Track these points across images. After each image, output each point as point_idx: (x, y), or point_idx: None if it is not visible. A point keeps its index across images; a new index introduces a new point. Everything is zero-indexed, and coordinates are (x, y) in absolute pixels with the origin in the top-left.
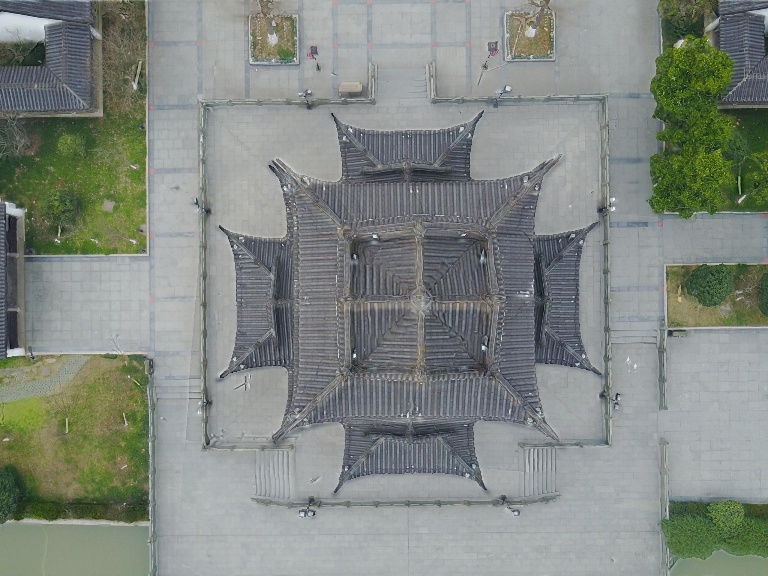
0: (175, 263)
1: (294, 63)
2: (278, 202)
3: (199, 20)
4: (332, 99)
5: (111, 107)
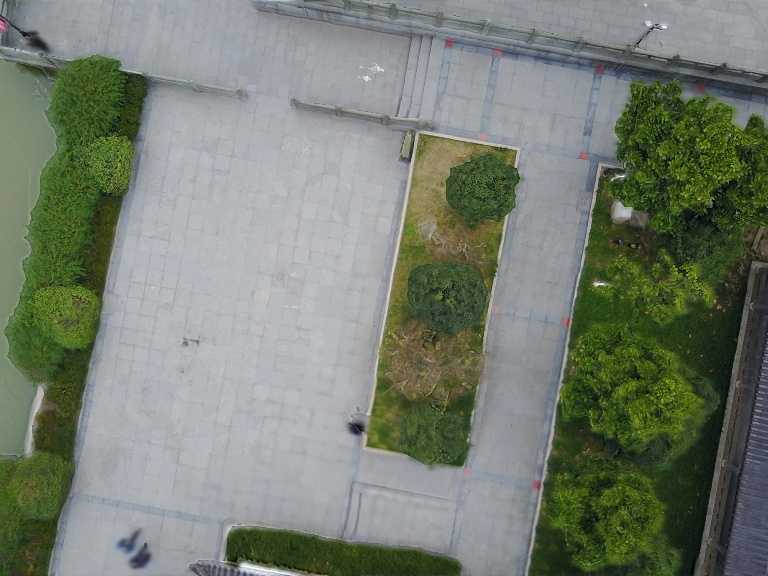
0: None
1: None
2: None
3: None
4: None
5: None
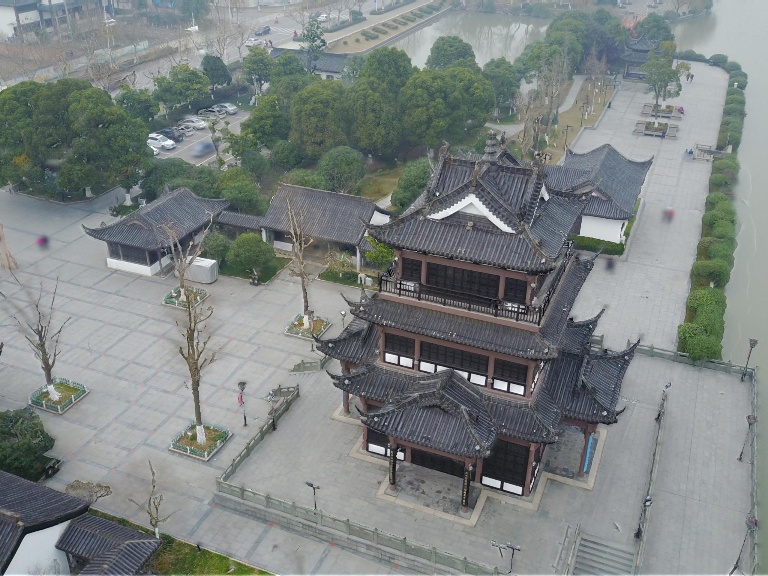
0: (347, 575)
1: (230, 436)
2: (339, 471)
3: (142, 481)
4: (280, 407)
5: (159, 569)
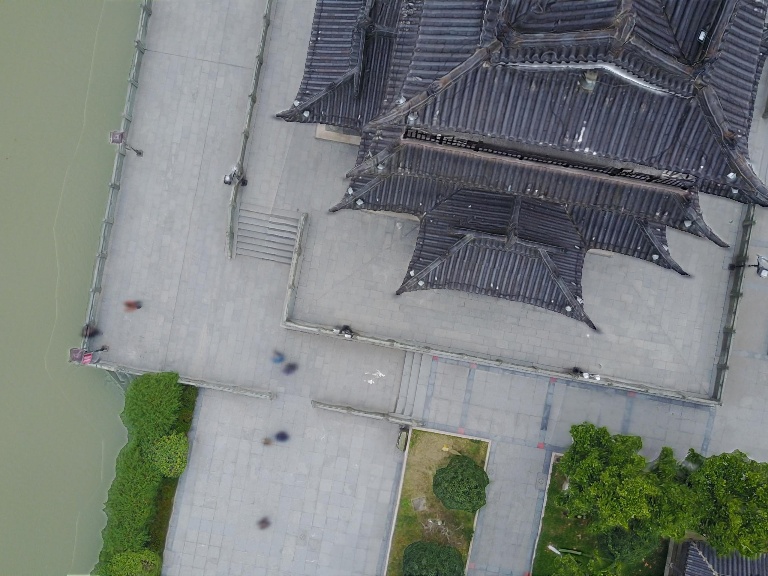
0: None
1: None
2: None
3: None
4: None
5: None
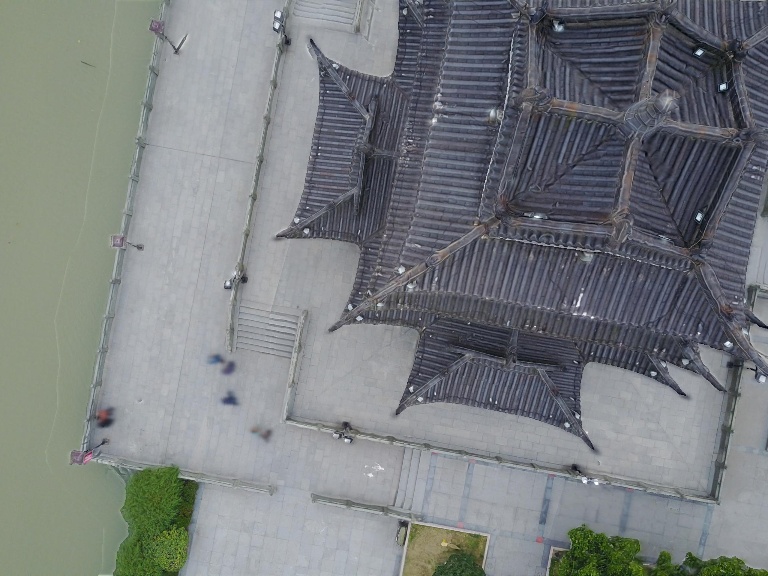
0: None
1: None
2: None
3: None
4: None
5: None
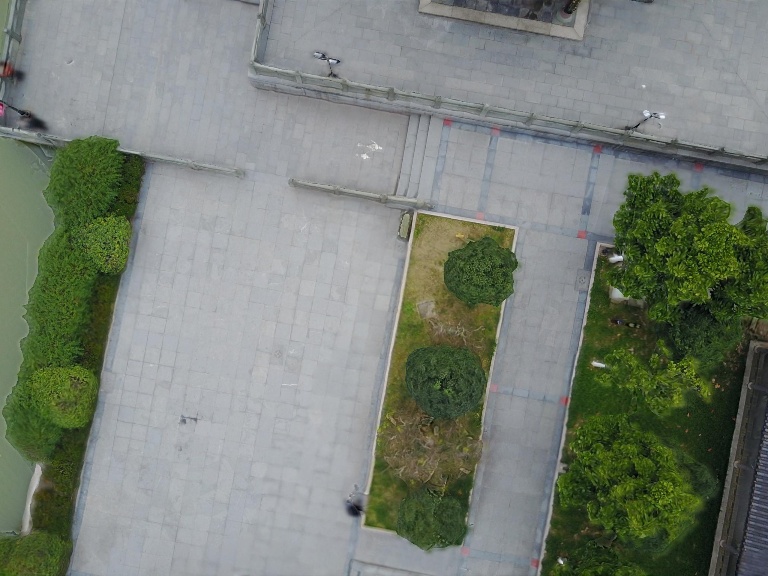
0: None
1: None
2: None
3: None
4: None
5: None
